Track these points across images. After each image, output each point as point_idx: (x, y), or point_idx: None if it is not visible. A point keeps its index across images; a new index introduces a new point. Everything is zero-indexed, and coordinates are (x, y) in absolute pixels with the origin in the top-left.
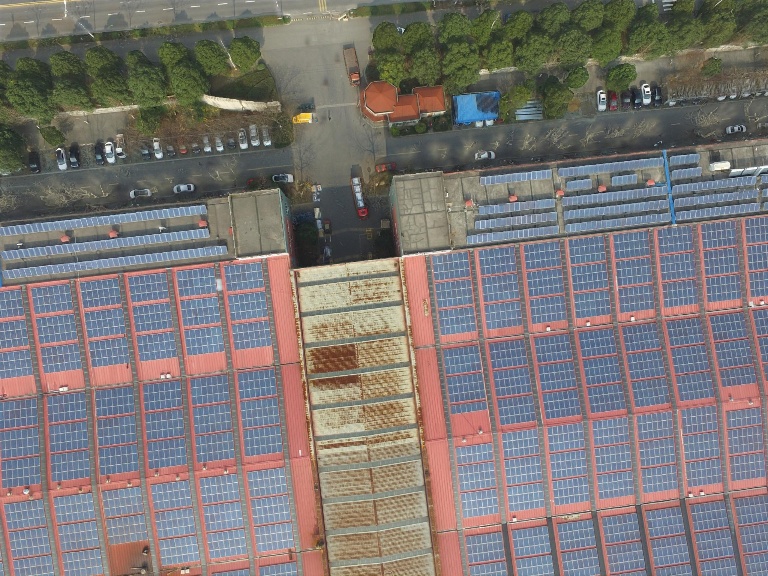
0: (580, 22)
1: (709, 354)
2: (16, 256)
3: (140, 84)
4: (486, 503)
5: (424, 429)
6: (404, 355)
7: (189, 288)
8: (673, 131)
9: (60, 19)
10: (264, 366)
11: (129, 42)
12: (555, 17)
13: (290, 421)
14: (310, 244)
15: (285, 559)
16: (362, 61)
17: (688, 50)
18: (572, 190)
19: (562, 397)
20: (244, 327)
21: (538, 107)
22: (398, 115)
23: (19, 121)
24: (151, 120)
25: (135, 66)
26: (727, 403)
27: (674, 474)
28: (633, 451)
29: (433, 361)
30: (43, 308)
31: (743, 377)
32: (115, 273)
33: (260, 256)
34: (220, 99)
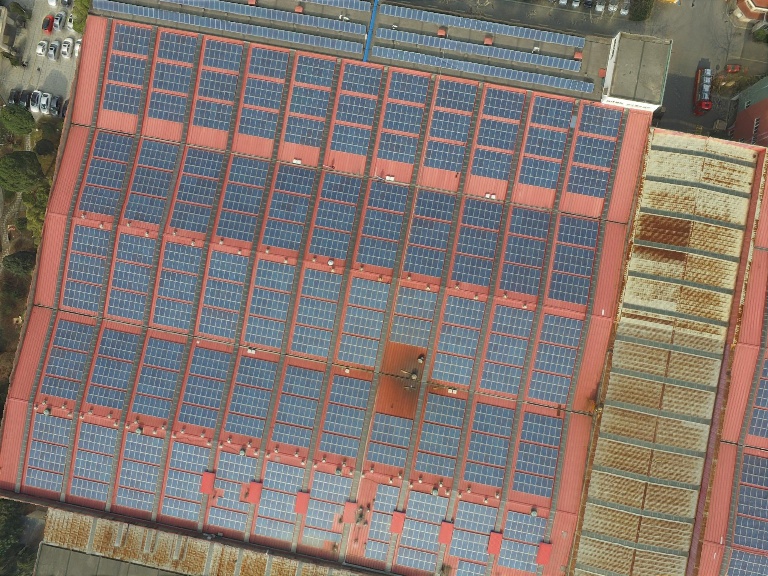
0: None
1: None
2: (389, 36)
3: None
4: None
5: (739, 329)
6: (736, 249)
7: (543, 116)
8: None
9: None
10: (589, 217)
11: None
12: None
13: (601, 278)
14: None
15: (552, 413)
16: None
17: None
18: None
19: None
20: (583, 171)
21: None
22: None
23: None
24: None
25: None
26: None
27: None
28: None
29: (764, 265)
30: (397, 94)
31: None
32: (476, 80)
33: (628, 103)
34: None
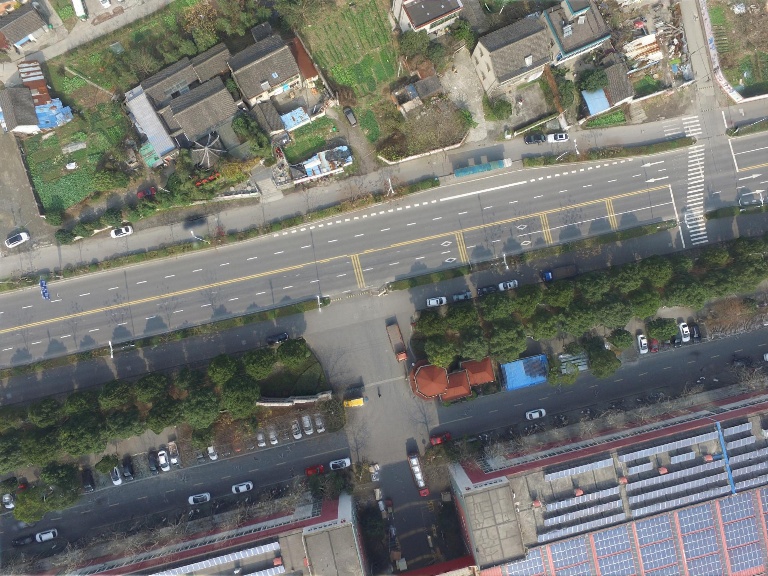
0: (620, 288)
1: None
2: None
3: (195, 416)
4: None
5: None
6: None
7: None
8: (713, 364)
9: (97, 329)
10: None
11: (170, 344)
12: (597, 291)
13: None
14: (377, 537)
15: None
16: (405, 333)
17: None
18: (634, 473)
19: None
20: None
21: (582, 358)
22: (450, 395)
23: None
24: (206, 436)
25: None
26: None
27: None
28: None
29: None
30: None
31: None
32: None
33: None
34: (273, 405)
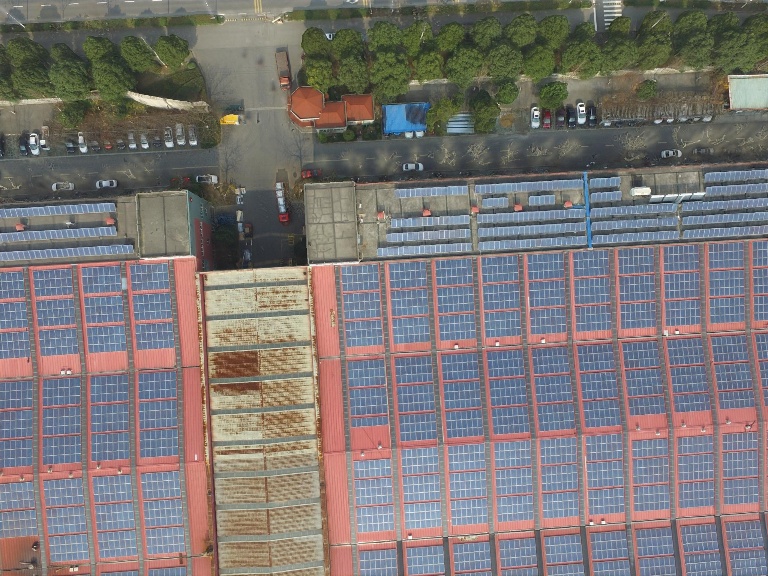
0: (512, 37)
1: (619, 381)
2: None
3: (60, 77)
4: (382, 519)
5: (322, 441)
6: (308, 365)
7: (94, 285)
8: (607, 152)
9: None
10: (166, 368)
11: (61, 34)
12: (485, 31)
13: (188, 425)
14: (227, 247)
15: (175, 563)
16: (295, 65)
17: (625, 71)
18: (488, 207)
19: (465, 416)
20: (147, 328)
21: (470, 121)
22: (324, 122)
23: None
24: (73, 114)
25: None
26: (634, 432)
27: (576, 501)
28: (535, 475)
29: (337, 372)
30: None
31: (652, 407)
32: (20, 266)
33: (165, 257)
34: (144, 96)
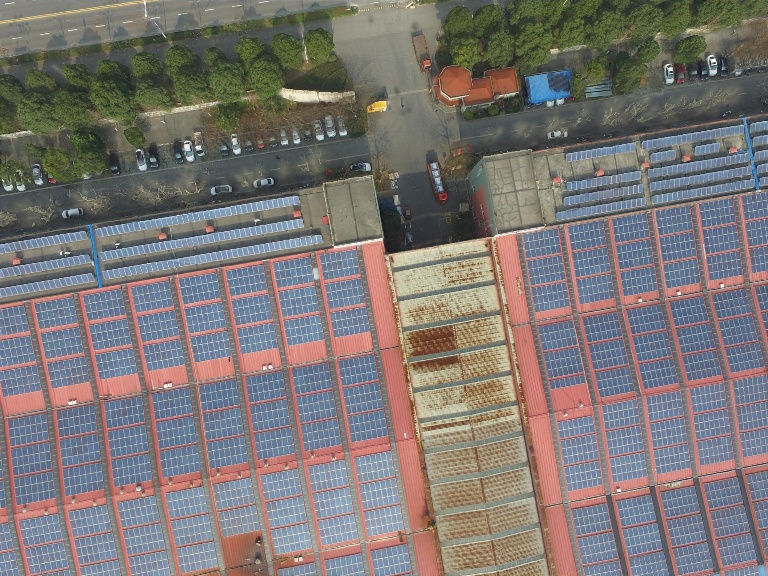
0: None
1: None
2: (115, 256)
3: (223, 80)
4: (590, 475)
5: (526, 405)
6: (500, 334)
7: (286, 279)
8: (740, 101)
9: (131, 21)
10: (363, 352)
11: (200, 41)
12: None
13: (393, 405)
14: (395, 230)
15: (396, 542)
16: (431, 47)
17: (752, 19)
18: (656, 162)
19: (658, 366)
20: (342, 314)
21: (607, 84)
22: (473, 98)
23: (100, 124)
24: (231, 116)
25: (214, 63)
26: None
27: None
28: (731, 416)
29: (529, 338)
30: (144, 306)
31: None
32: (213, 268)
33: (356, 243)
34: (298, 91)
